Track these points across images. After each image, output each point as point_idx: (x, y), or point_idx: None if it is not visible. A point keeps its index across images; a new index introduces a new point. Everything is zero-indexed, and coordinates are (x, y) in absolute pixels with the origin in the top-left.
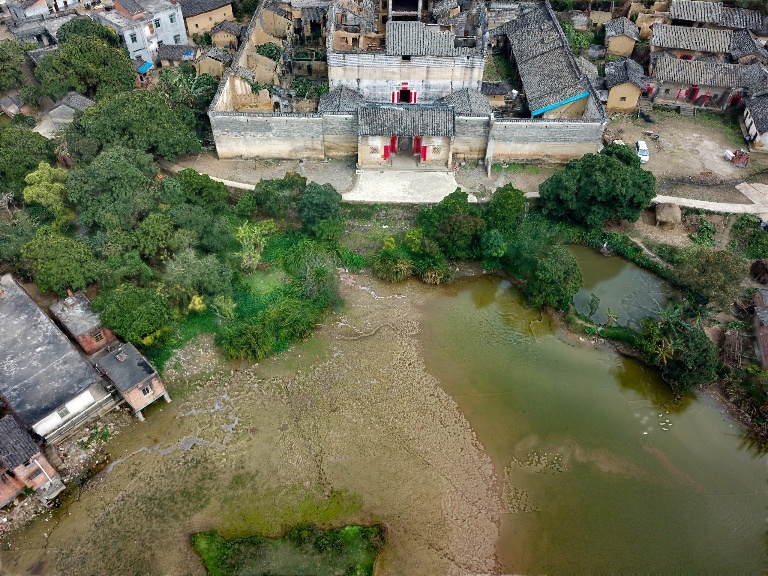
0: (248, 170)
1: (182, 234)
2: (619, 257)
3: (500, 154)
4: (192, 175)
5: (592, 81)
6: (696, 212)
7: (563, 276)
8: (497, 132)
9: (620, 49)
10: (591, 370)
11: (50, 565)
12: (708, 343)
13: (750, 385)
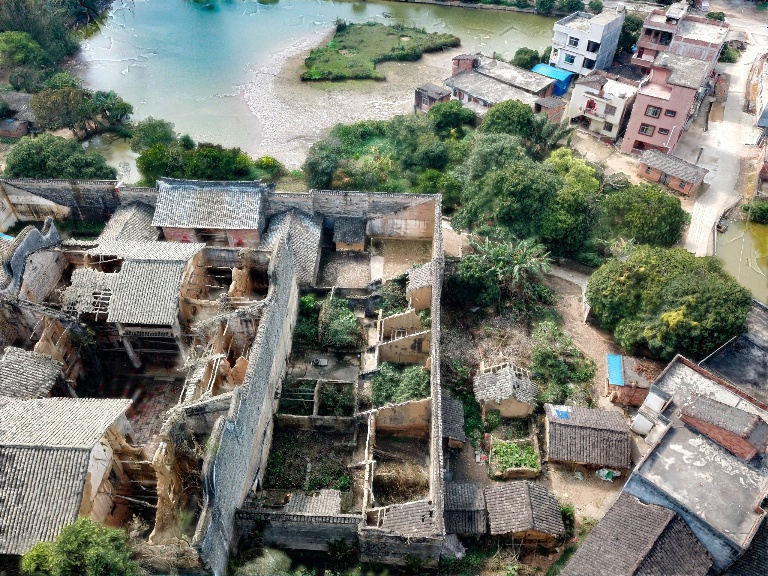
0: None
1: (428, 134)
2: None
3: None
4: None
5: None
6: None
7: None
8: None
9: None
10: None
11: None
12: None
13: (83, 104)
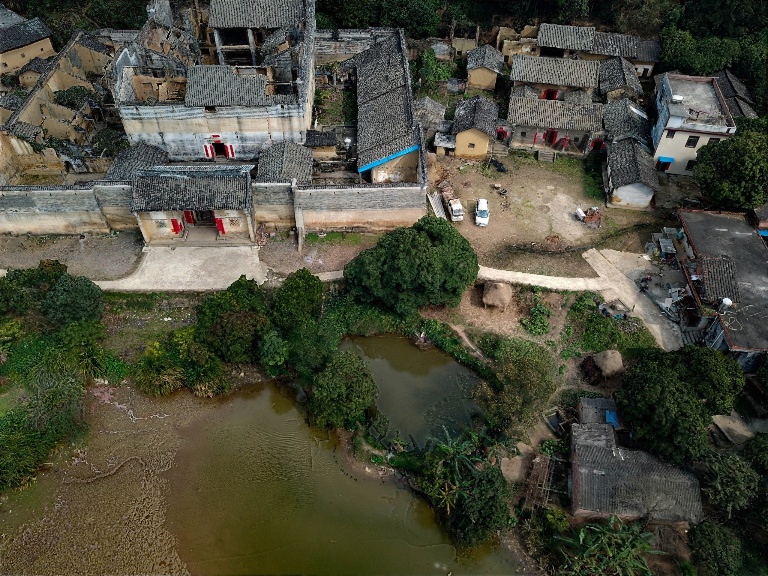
0: (15, 250)
1: None
2: (437, 350)
3: (313, 222)
4: None
5: (438, 125)
6: (531, 290)
7: (346, 392)
8: (302, 200)
9: (482, 82)
10: (370, 515)
11: None
12: (496, 488)
13: (551, 535)
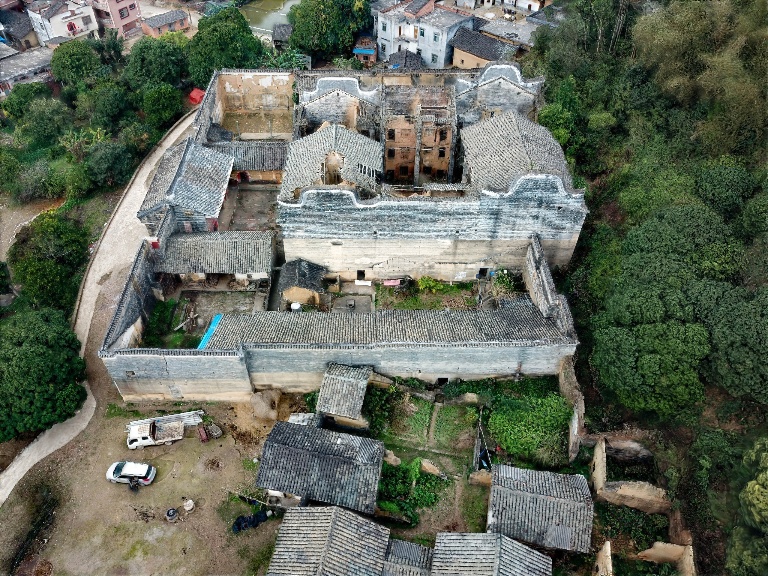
0: None
1: (81, 97)
2: None
3: None
4: (160, 92)
5: None
6: None
7: None
8: None
9: None
10: None
11: None
12: None
13: None
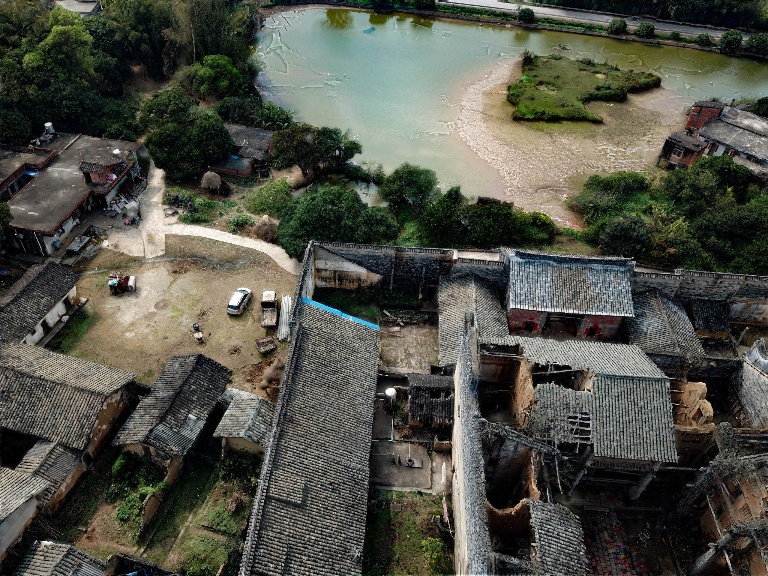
0: None
1: (727, 196)
2: None
3: None
4: None
5: None
6: None
7: None
8: None
9: None
10: (388, 164)
11: (661, 121)
12: (324, 129)
13: None
